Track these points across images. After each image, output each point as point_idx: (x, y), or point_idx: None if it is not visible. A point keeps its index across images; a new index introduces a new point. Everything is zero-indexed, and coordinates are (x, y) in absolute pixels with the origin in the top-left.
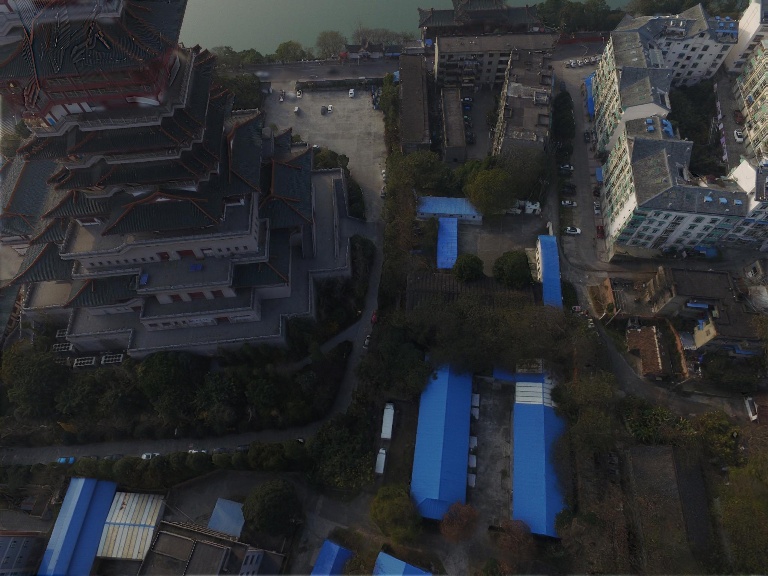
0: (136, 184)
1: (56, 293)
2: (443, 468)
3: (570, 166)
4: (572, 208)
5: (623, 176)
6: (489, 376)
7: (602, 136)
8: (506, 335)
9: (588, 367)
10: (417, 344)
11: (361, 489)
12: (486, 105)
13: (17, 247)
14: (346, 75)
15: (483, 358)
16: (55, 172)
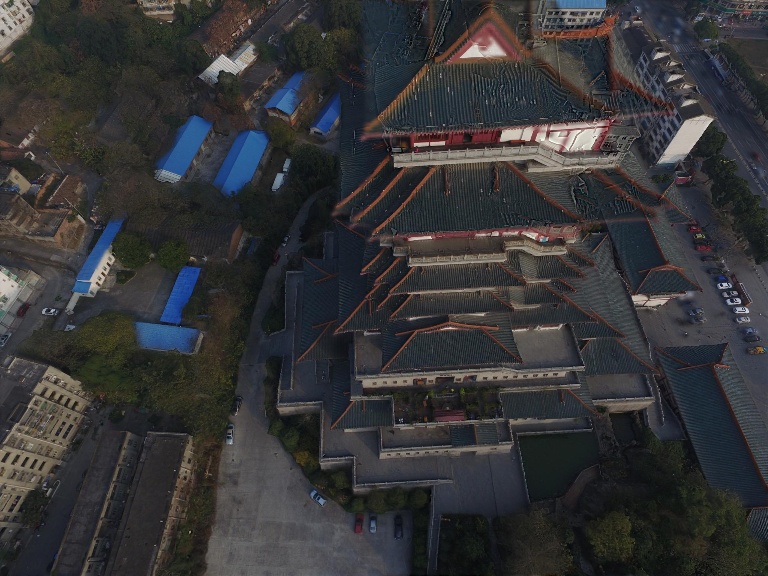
0: None
1: None
2: None
3: None
4: None
5: None
6: None
7: None
8: None
9: None
10: None
11: None
12: (25, 568)
13: None
14: None
15: None
16: None
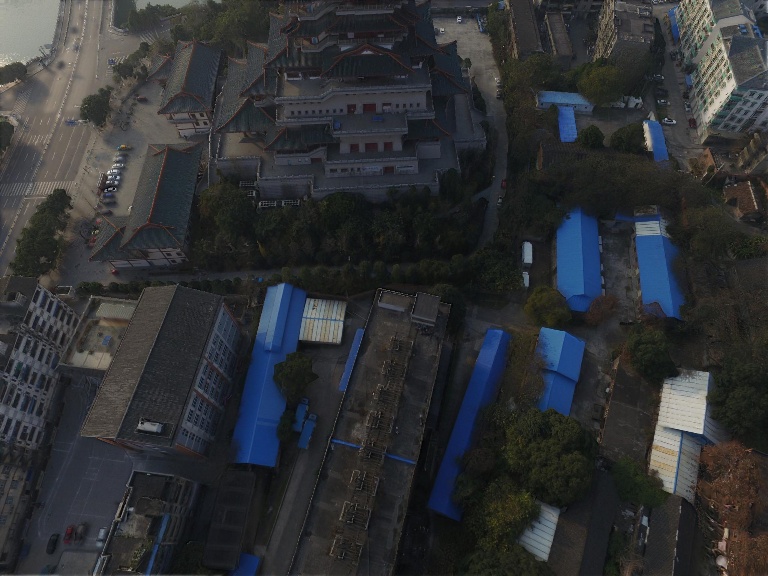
0: (351, 36)
1: (241, 149)
2: (585, 275)
3: (661, 76)
4: (666, 106)
5: (718, 71)
6: (611, 219)
7: (690, 51)
8: (633, 179)
9: (697, 208)
10: (549, 196)
11: (509, 300)
12: (581, 31)
13: (181, 127)
14: (452, 5)
15: (612, 198)
16: (283, 26)
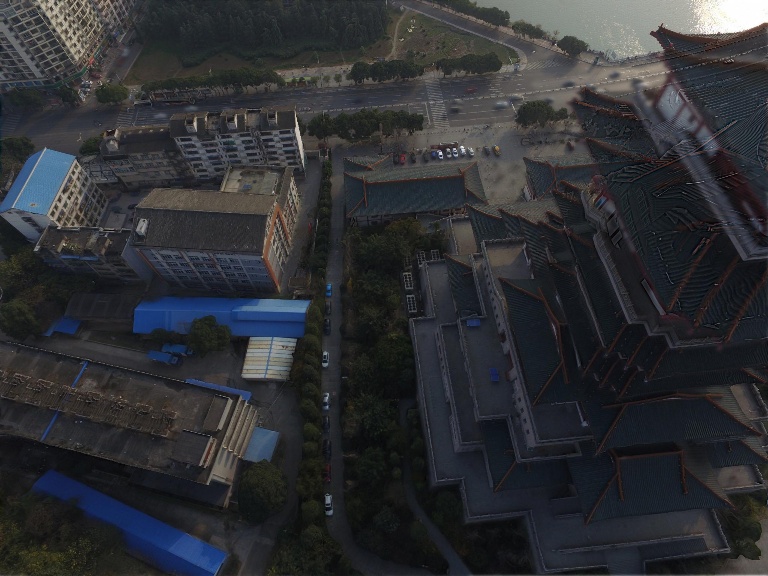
0: None
1: (470, 239)
2: None
3: None
4: None
5: None
6: None
7: None
8: None
9: None
10: None
11: None
12: None
13: None
14: None
15: None
16: None
